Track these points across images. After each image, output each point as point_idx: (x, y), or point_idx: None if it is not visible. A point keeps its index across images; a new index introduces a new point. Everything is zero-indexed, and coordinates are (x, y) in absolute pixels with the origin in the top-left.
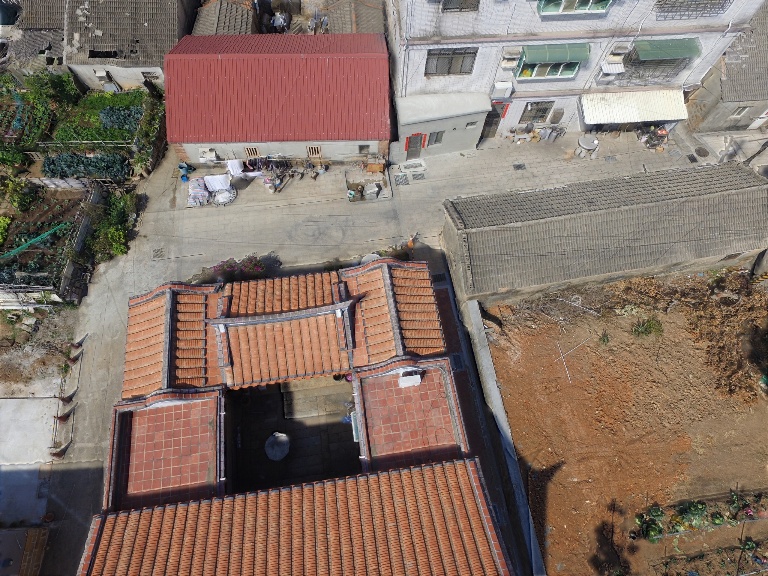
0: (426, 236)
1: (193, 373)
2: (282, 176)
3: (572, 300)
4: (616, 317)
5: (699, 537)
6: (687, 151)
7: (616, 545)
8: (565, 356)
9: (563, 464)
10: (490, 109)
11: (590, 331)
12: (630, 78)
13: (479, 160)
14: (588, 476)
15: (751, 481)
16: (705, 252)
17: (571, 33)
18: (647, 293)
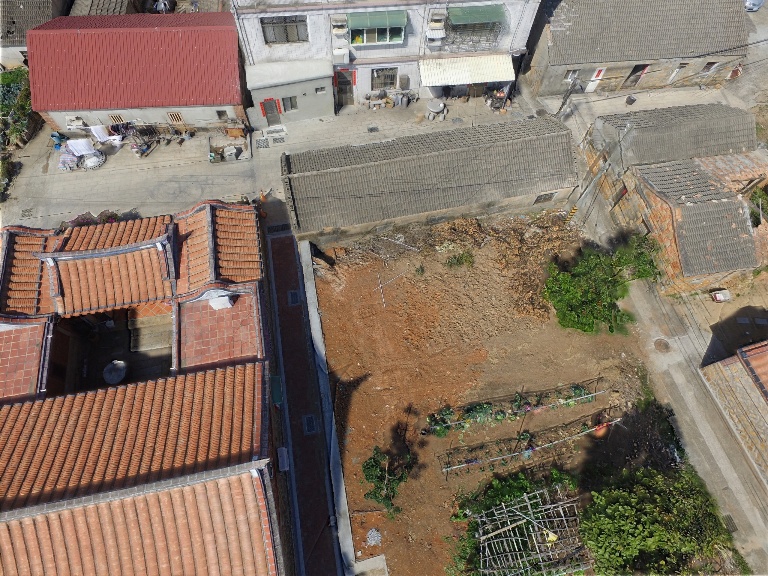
0: (279, 191)
1: (25, 303)
2: (150, 142)
3: (396, 239)
4: (435, 252)
5: (482, 431)
6: (528, 112)
7: (407, 441)
8: (383, 286)
9: (369, 376)
10: (332, 74)
11: (409, 264)
12: (454, 43)
13: (336, 125)
14: (390, 385)
15: (536, 384)
16: (513, 192)
17: (386, 1)
18: (467, 232)
